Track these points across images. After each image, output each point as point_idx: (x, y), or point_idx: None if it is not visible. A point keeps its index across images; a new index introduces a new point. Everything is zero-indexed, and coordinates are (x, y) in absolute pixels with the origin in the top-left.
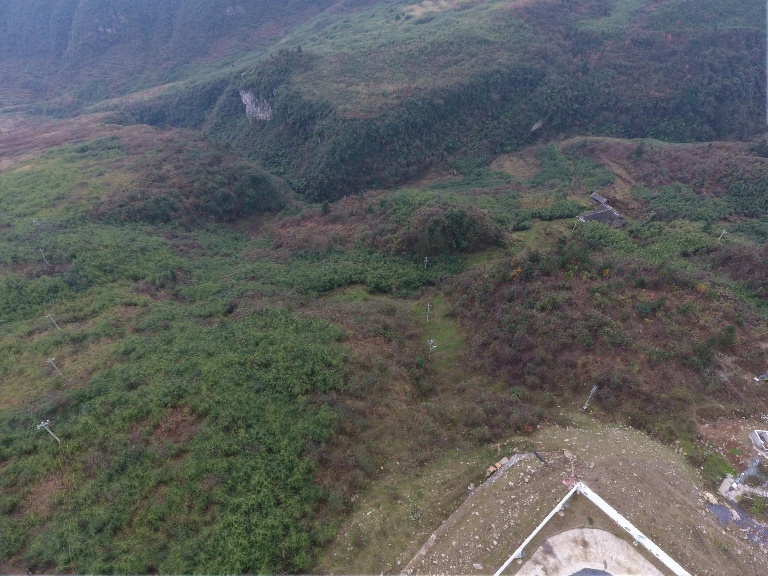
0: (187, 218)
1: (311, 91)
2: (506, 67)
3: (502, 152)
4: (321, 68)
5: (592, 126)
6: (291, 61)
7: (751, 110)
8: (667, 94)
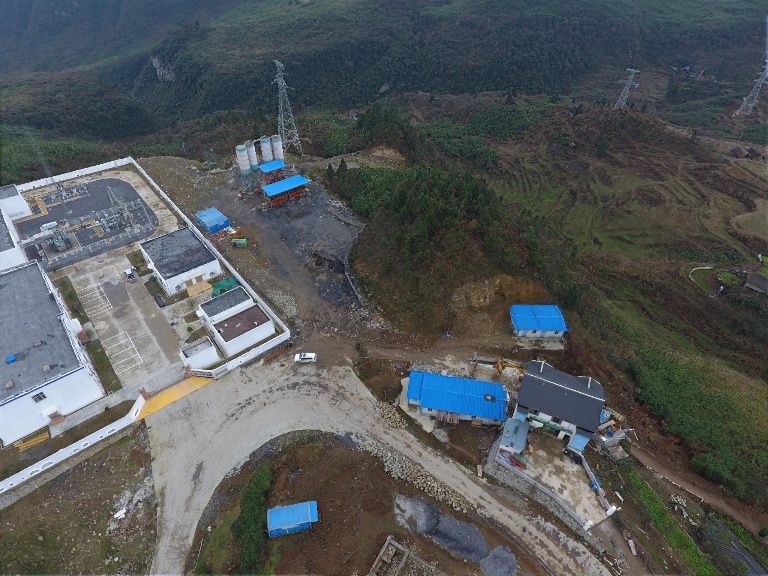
0: (68, 129)
1: (200, 54)
2: (356, 39)
3: (354, 107)
4: (212, 38)
5: (427, 89)
6: (189, 32)
7: (548, 78)
8: (480, 63)
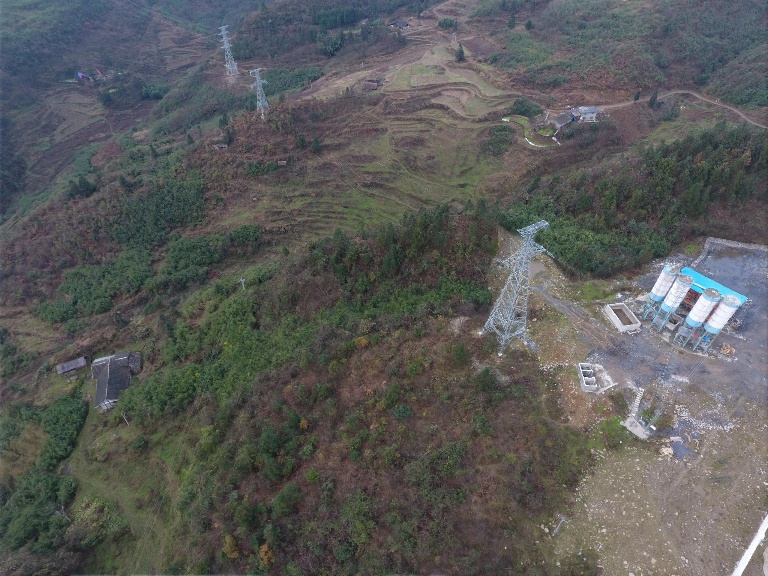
0: None
1: None
2: None
3: None
4: None
5: None
6: None
7: None
8: None
